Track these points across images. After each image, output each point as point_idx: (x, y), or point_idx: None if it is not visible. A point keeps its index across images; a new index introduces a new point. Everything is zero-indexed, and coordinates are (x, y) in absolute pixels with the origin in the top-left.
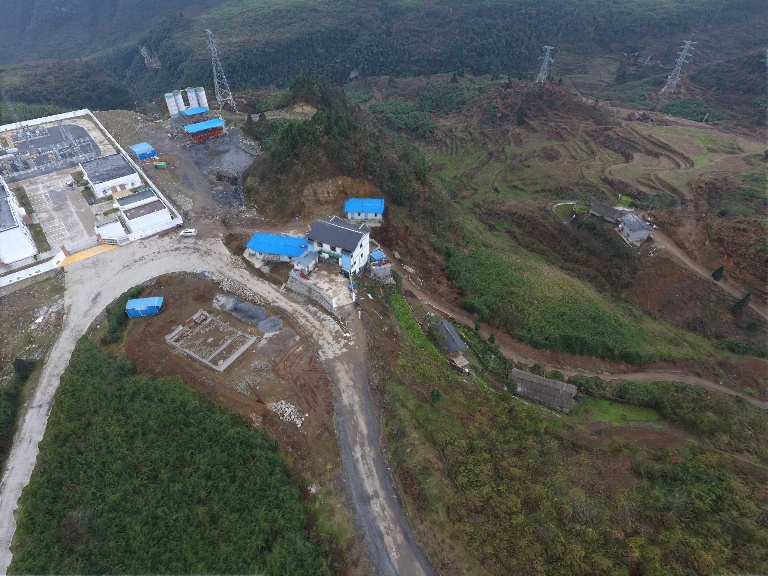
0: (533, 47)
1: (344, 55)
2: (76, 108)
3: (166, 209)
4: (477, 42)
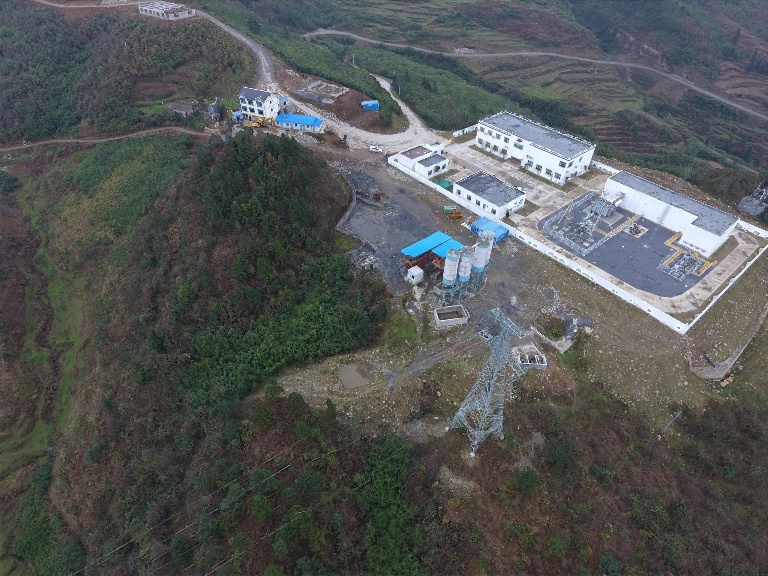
0: None
1: None
2: None
3: None
4: None
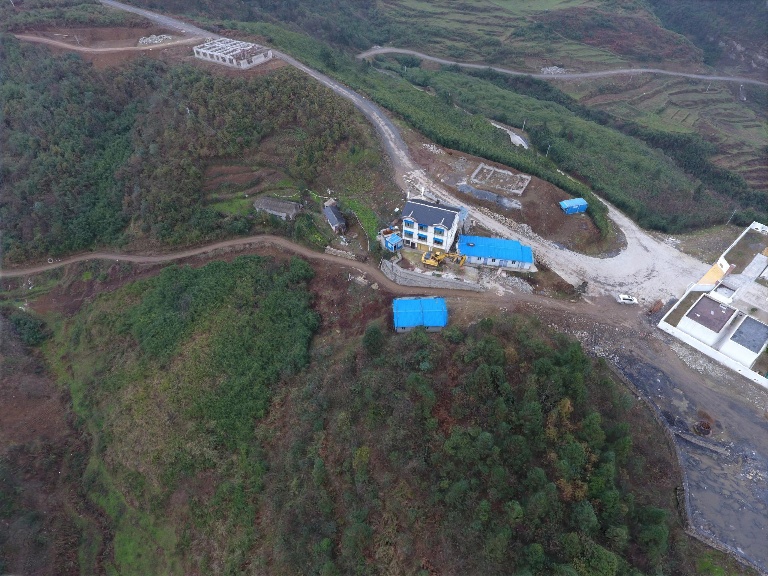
0: None
1: None
2: None
3: (685, 315)
4: None
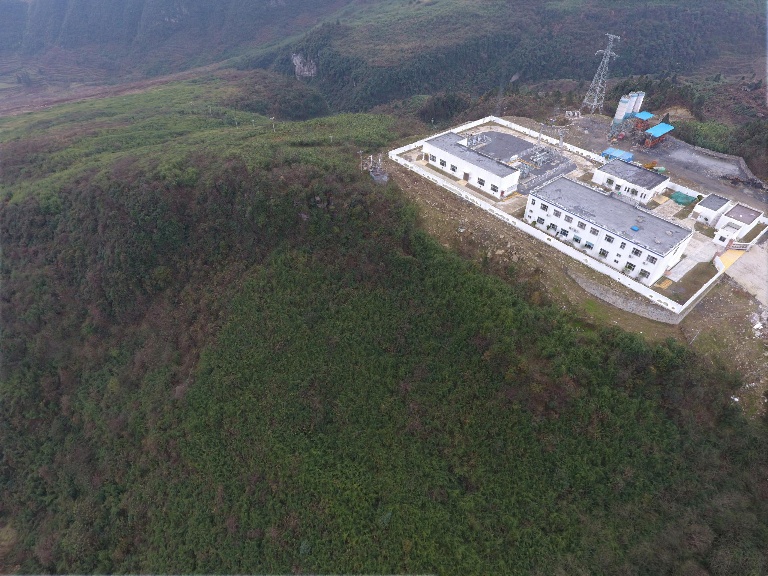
0: (698, 47)
1: (506, 59)
2: (289, 117)
3: (763, 213)
4: (646, 44)
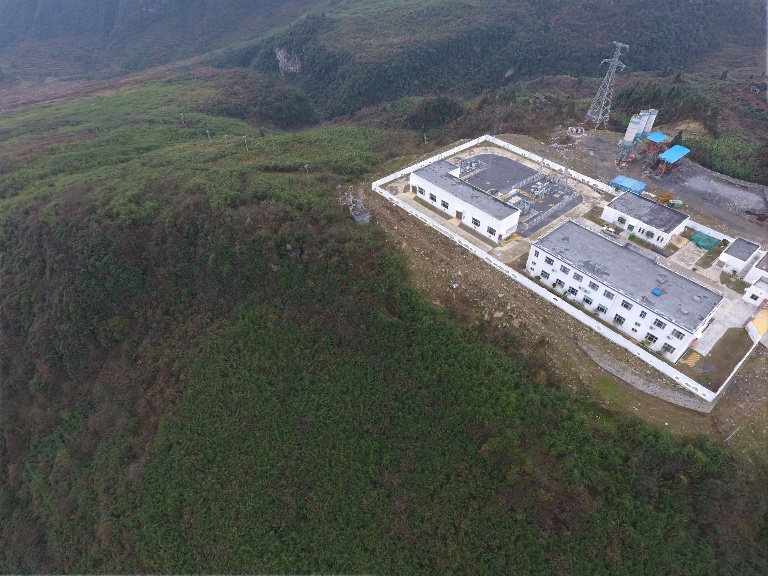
0: (700, 39)
1: (501, 53)
2: (271, 120)
3: None
4: (647, 36)
